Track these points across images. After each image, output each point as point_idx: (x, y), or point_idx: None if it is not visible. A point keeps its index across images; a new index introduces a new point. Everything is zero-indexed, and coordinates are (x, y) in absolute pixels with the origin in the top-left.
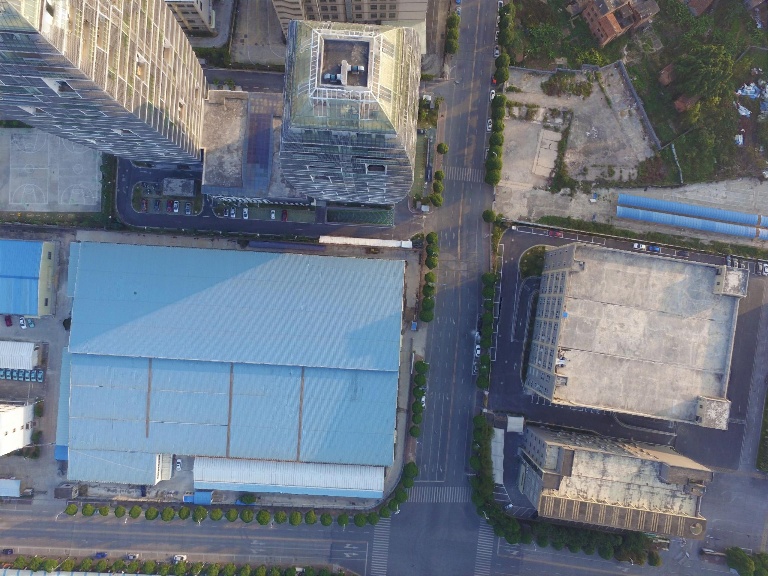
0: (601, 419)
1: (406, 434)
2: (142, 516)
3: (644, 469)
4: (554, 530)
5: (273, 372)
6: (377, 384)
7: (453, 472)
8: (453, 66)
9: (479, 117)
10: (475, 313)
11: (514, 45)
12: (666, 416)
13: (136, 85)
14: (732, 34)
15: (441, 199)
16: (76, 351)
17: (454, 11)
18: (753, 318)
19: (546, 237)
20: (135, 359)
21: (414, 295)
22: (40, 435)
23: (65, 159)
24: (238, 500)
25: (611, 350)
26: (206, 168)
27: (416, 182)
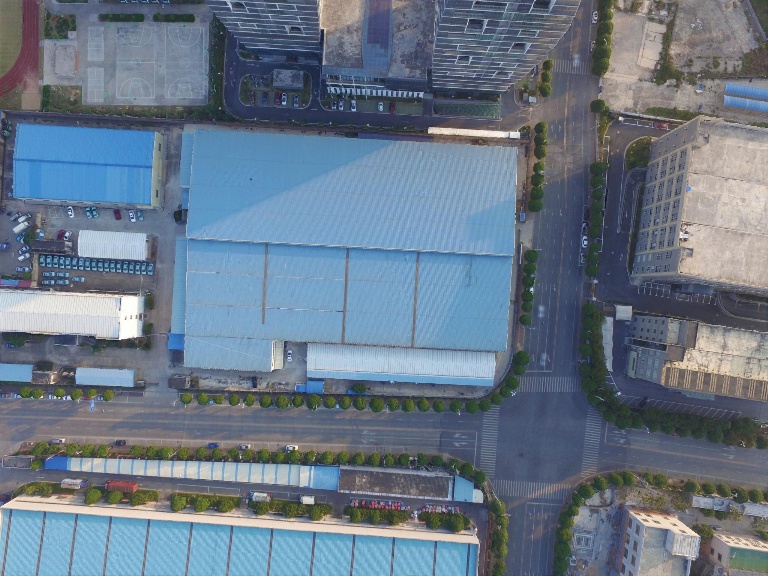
0: (707, 309)
1: (515, 324)
2: (253, 407)
3: (764, 344)
4: (664, 415)
5: (388, 258)
6: (491, 269)
7: (560, 362)
8: None
9: (584, 10)
10: (581, 205)
11: None
12: None
13: None
14: None
15: (551, 88)
16: (194, 236)
17: None
18: None
19: (651, 129)
20: (251, 245)
21: (521, 187)
22: (151, 327)
23: (171, 53)
24: (349, 390)
25: (733, 225)
26: (326, 49)
27: None
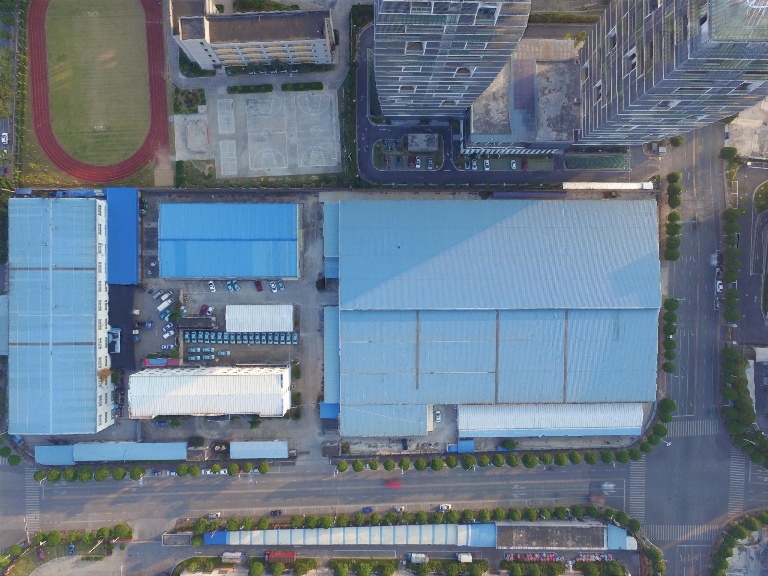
0: None
1: (656, 371)
2: None
3: None
4: None
5: (538, 317)
6: (638, 322)
7: (702, 406)
8: None
9: None
10: (713, 250)
11: None
12: None
13: None
14: None
15: None
16: (347, 308)
17: None
18: None
19: None
20: (403, 312)
21: None
22: (299, 397)
23: (302, 122)
24: (499, 447)
25: None
26: (474, 117)
27: None
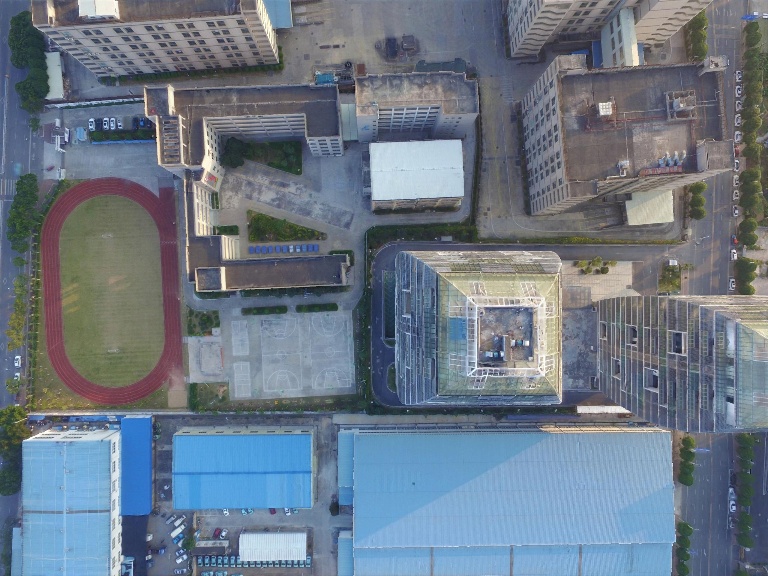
0: None
1: None
2: None
3: None
4: None
5: (552, 551)
6: (652, 555)
7: None
8: (693, 227)
9: (721, 276)
10: (727, 469)
11: None
12: None
13: None
14: None
15: None
16: (362, 547)
17: None
18: None
19: None
20: (417, 548)
21: None
22: None
23: (316, 343)
24: None
25: None
26: None
27: None
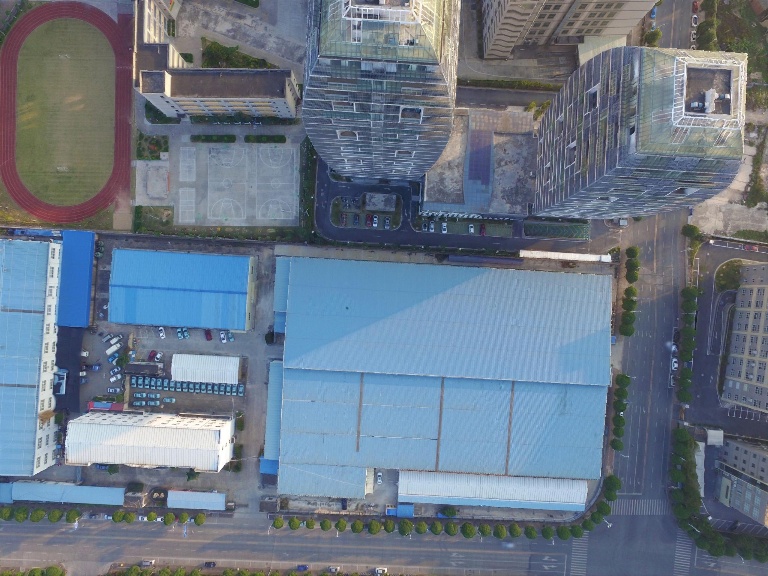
0: None
1: (605, 447)
2: None
3: None
4: (758, 543)
5: (483, 386)
6: (586, 398)
7: (650, 485)
8: None
9: None
10: (671, 327)
11: None
12: None
13: None
14: None
15: None
16: (291, 366)
17: (649, 26)
18: None
19: (741, 251)
20: (347, 374)
21: None
22: (241, 449)
23: (263, 174)
24: (439, 513)
25: None
26: (427, 184)
27: None
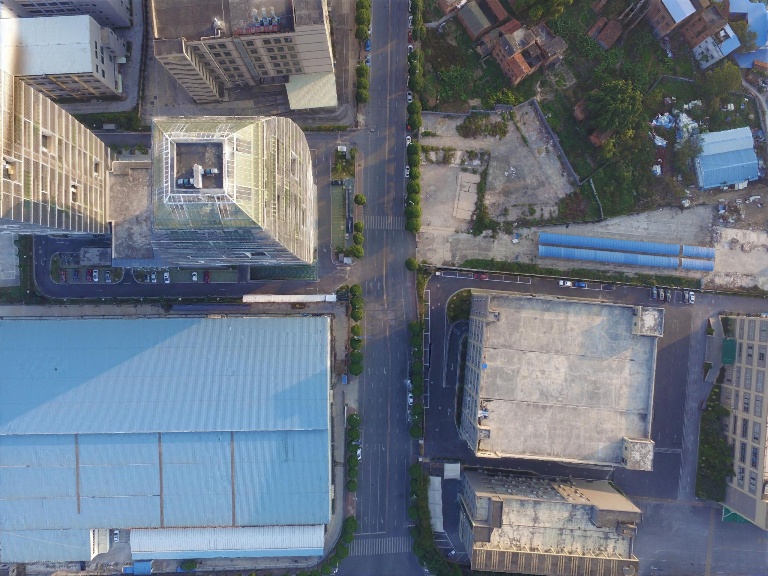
0: None
1: (344, 488)
2: None
3: (575, 513)
4: (496, 575)
5: (202, 439)
6: (308, 443)
7: (394, 522)
8: (367, 114)
9: (396, 164)
10: (406, 361)
11: (426, 90)
12: (593, 460)
13: (5, 188)
14: (642, 65)
15: (361, 251)
16: None
17: (364, 59)
18: (683, 347)
19: (471, 280)
20: (60, 436)
21: (343, 347)
22: None
23: None
24: (179, 567)
25: (534, 398)
26: (115, 241)
27: (337, 234)
